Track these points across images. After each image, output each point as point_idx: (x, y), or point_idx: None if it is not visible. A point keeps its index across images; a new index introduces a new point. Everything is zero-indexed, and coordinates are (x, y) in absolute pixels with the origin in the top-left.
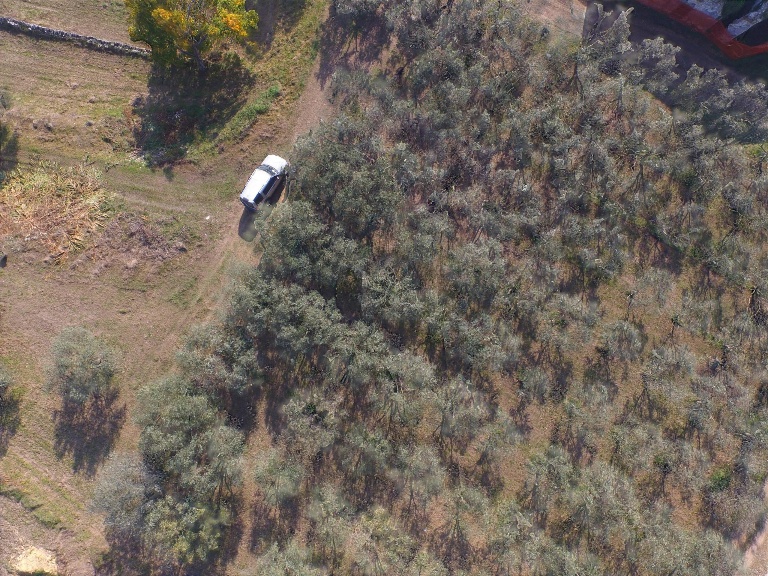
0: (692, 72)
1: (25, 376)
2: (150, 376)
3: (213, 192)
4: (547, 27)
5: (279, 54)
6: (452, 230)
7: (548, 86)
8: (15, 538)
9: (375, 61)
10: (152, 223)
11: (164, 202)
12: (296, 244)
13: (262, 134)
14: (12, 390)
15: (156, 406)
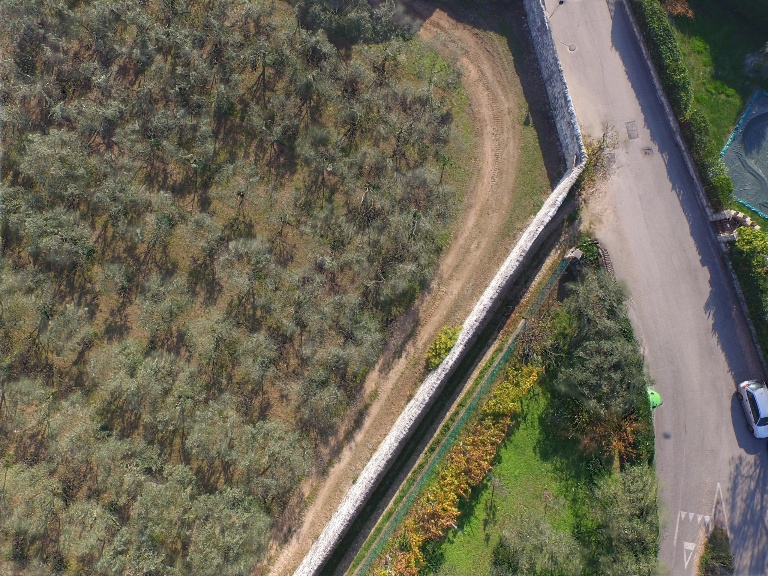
0: None
1: None
2: None
3: None
4: None
5: None
6: None
7: None
8: None
9: None
10: None
11: None
12: None
13: None
14: None
15: None
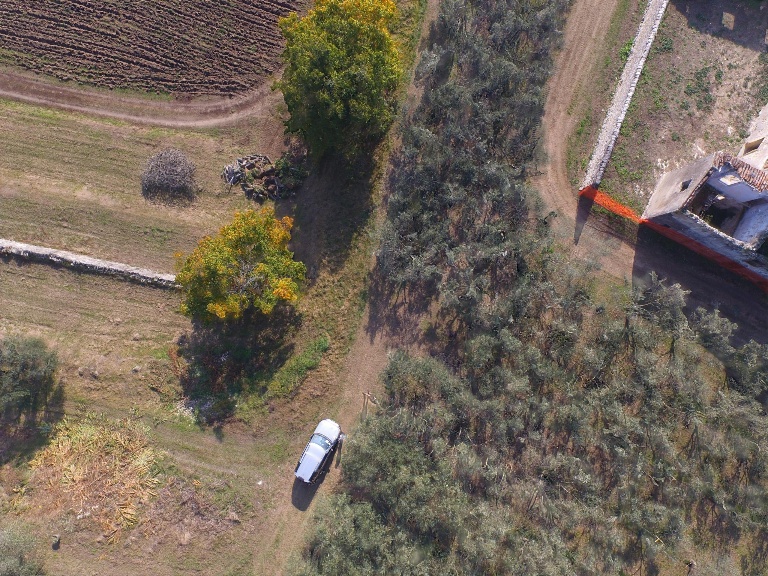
0: (749, 348)
1: None
2: None
3: (264, 455)
4: (596, 273)
5: (325, 296)
6: (507, 495)
7: (599, 338)
8: None
9: (424, 313)
10: (204, 490)
11: (215, 464)
12: (359, 555)
13: (313, 393)
14: None
15: None
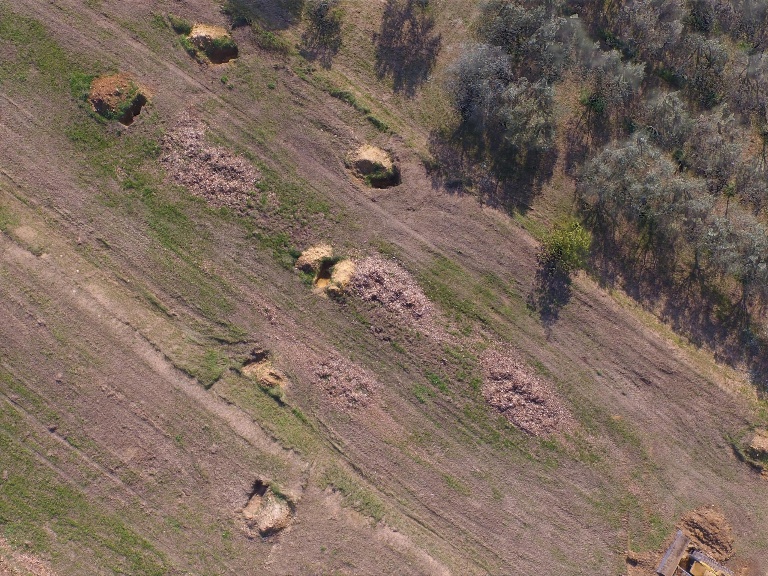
0: None
1: (344, 0)
2: (463, 9)
3: None
4: None
5: None
6: None
7: None
8: (351, 136)
9: None
10: None
11: None
12: None
13: None
14: (333, 12)
15: (470, 37)
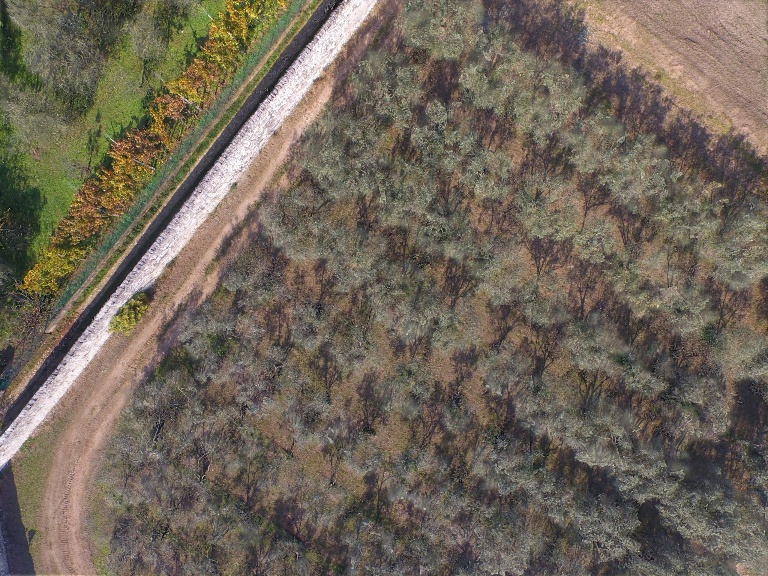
0: None
1: None
2: None
3: None
4: None
5: None
6: None
7: None
8: None
9: None
10: None
11: None
12: None
13: None
14: None
15: None
